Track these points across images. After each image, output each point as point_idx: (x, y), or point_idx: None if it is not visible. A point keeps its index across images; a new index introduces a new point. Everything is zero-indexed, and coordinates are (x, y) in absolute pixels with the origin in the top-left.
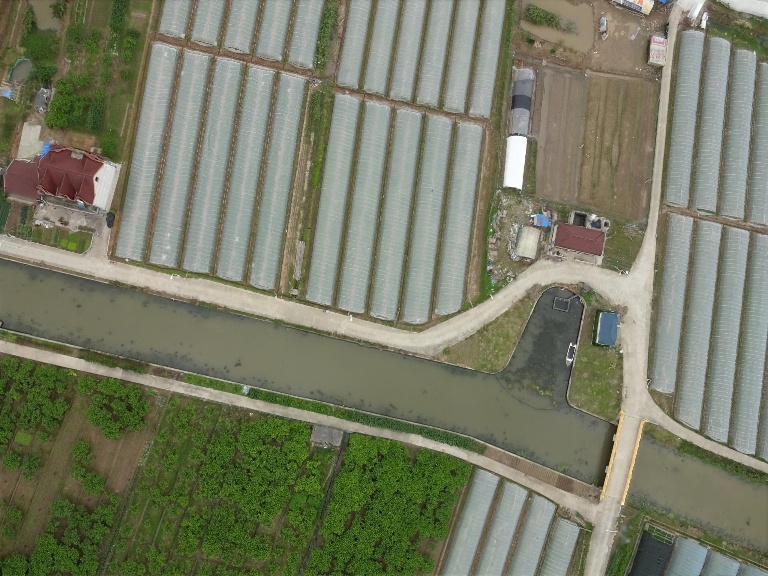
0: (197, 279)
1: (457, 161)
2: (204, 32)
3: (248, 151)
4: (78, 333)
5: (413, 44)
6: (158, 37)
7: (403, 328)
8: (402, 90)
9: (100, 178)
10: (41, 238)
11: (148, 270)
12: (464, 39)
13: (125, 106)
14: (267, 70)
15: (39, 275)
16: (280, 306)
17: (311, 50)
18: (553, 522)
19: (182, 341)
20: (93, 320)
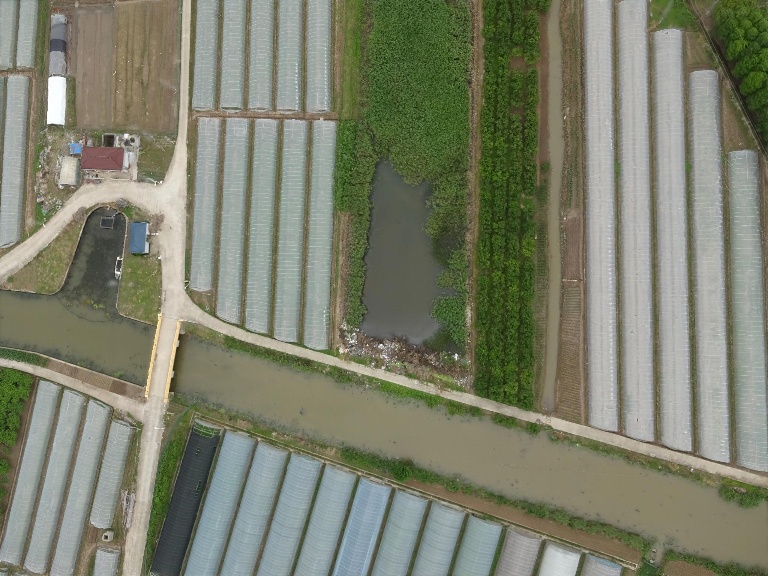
0: None
1: (7, 111)
2: None
3: None
4: None
5: None
6: None
7: None
8: None
9: None
10: None
11: None
12: None
13: None
14: None
15: None
16: None
17: None
18: (110, 424)
19: None
20: None
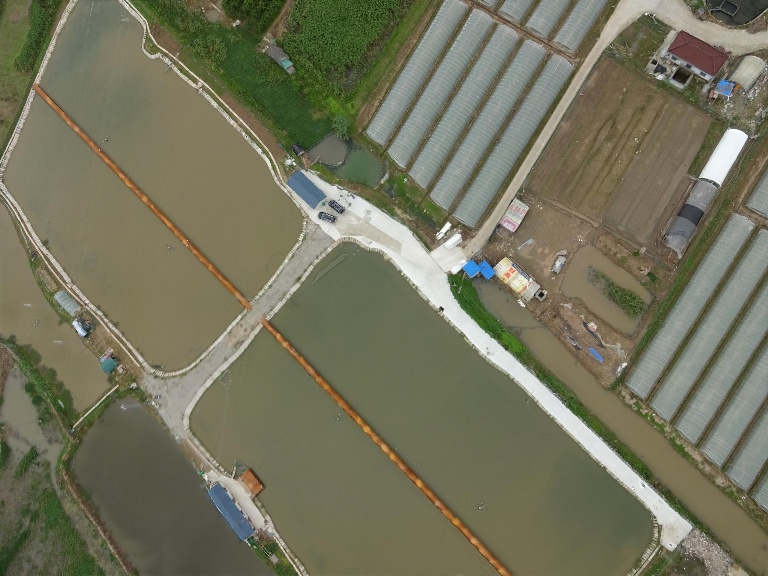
0: None
1: None
2: None
3: None
4: None
5: None
6: None
7: None
8: None
9: None
10: None
11: None
12: (728, 306)
13: None
14: None
15: None
16: None
17: None
18: None
19: None
20: None
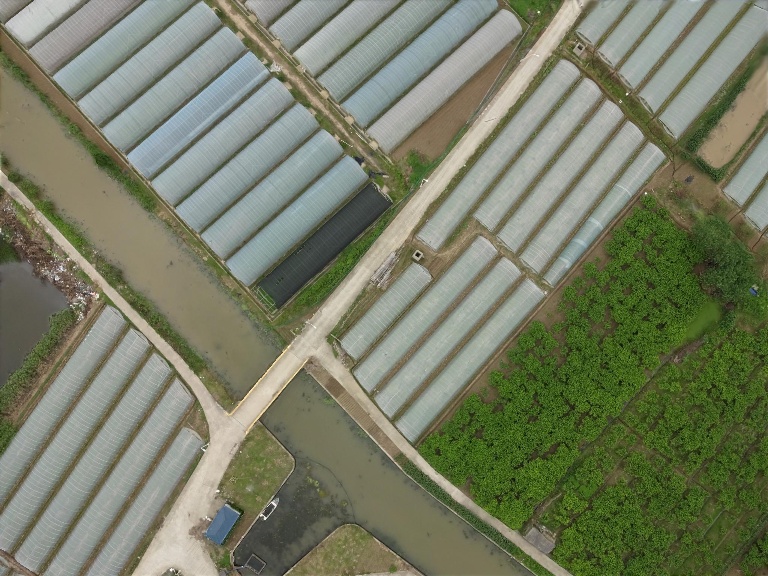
0: None
1: None
2: None
3: None
4: None
5: None
6: None
7: None
8: None
9: None
10: None
11: None
12: None
13: None
14: None
15: None
16: None
17: None
18: (362, 358)
19: None
20: None
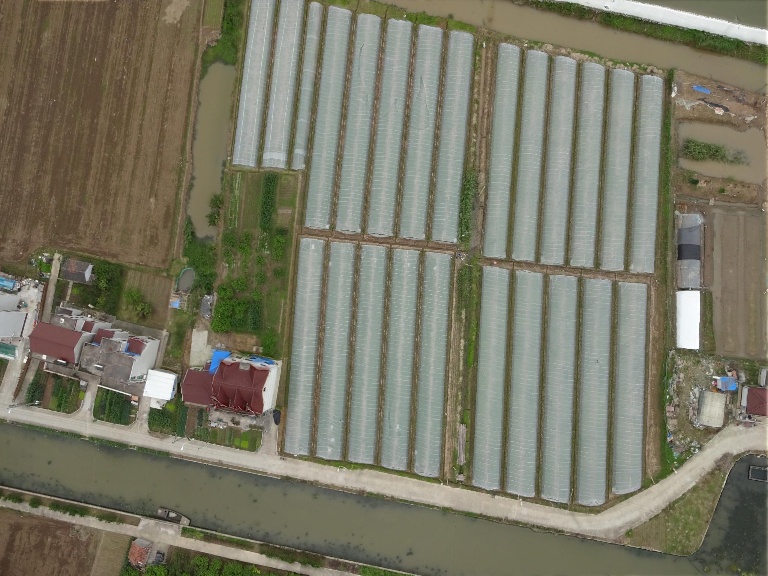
0: (363, 470)
1: (621, 324)
2: (347, 221)
3: (400, 336)
4: (257, 527)
5: (561, 203)
6: (304, 231)
7: (578, 510)
8: (554, 255)
9: (267, 385)
10: (217, 438)
11: (316, 464)
12: (616, 189)
13: (280, 302)
14: (411, 249)
15: (218, 473)
16: (447, 493)
17: (454, 224)
18: None
19: (353, 532)
20: (269, 514)
